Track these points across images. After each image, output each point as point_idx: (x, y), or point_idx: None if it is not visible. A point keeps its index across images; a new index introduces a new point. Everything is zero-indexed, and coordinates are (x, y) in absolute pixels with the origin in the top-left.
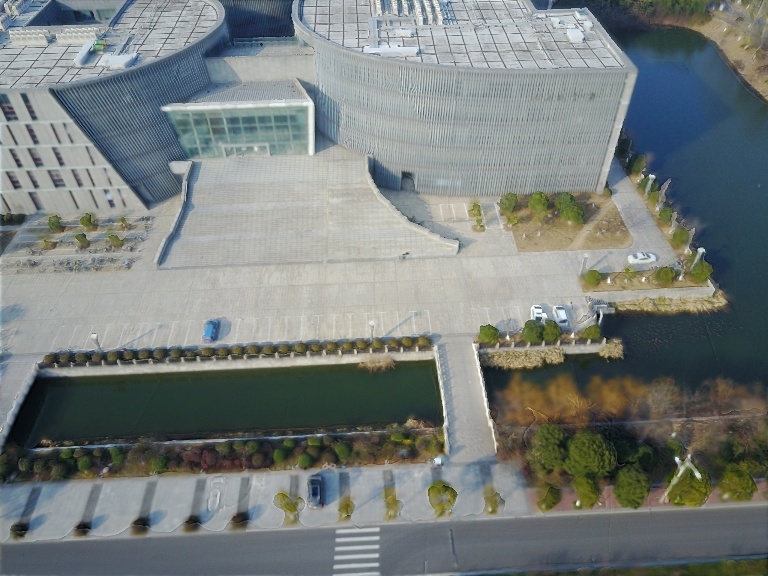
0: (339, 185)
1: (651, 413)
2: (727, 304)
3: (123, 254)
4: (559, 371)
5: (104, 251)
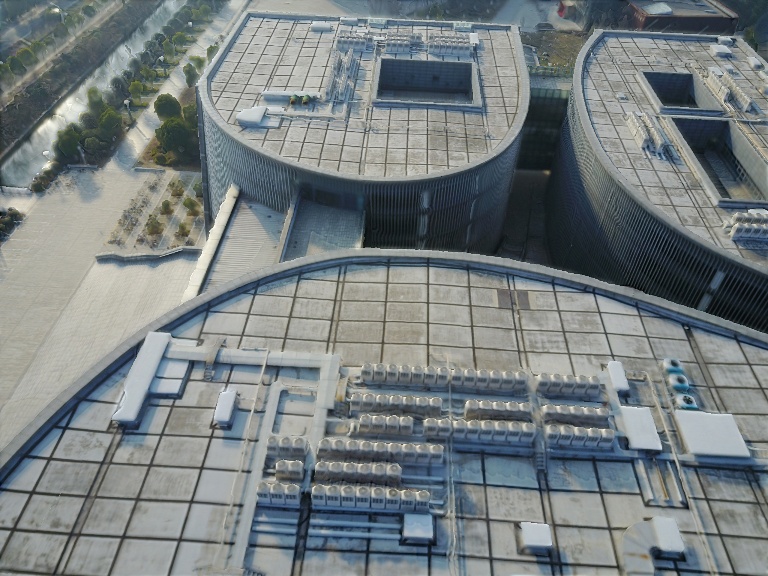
0: None
1: None
2: None
3: (135, 236)
4: None
5: (145, 223)
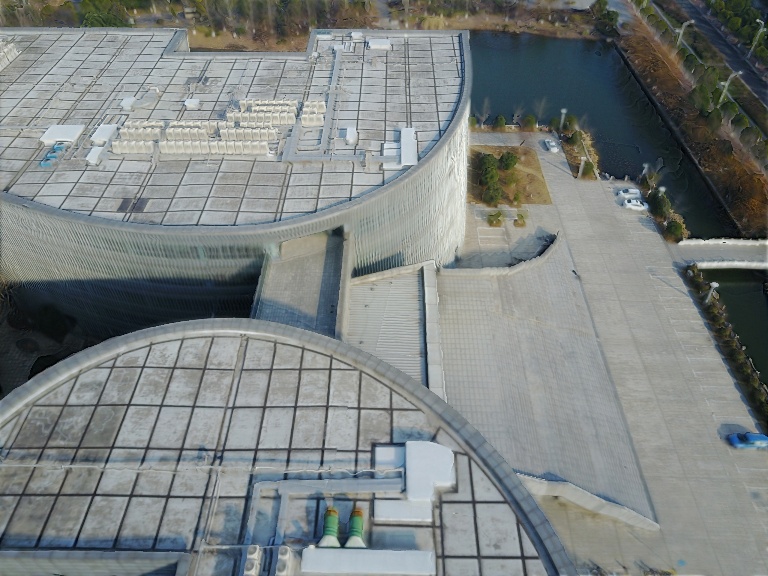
0: (495, 302)
1: (696, 180)
2: (581, 129)
3: None
4: (675, 211)
5: None
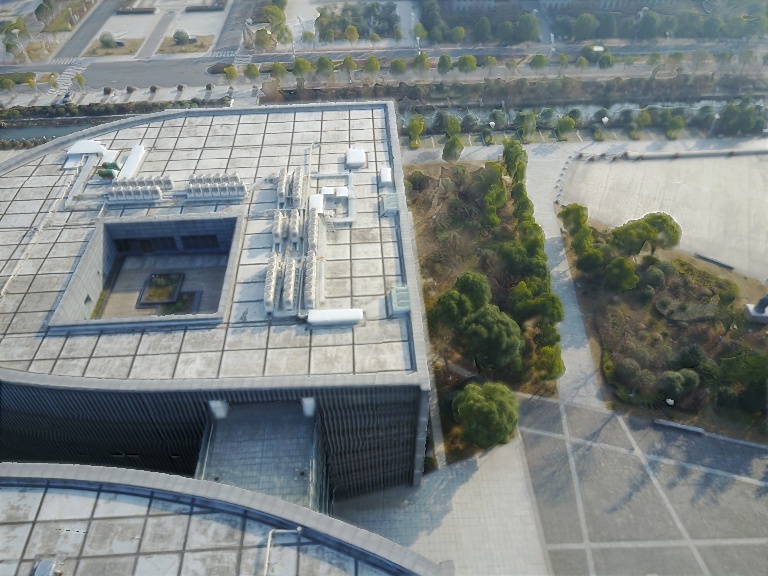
0: None
1: None
2: None
3: None
4: None
5: None
